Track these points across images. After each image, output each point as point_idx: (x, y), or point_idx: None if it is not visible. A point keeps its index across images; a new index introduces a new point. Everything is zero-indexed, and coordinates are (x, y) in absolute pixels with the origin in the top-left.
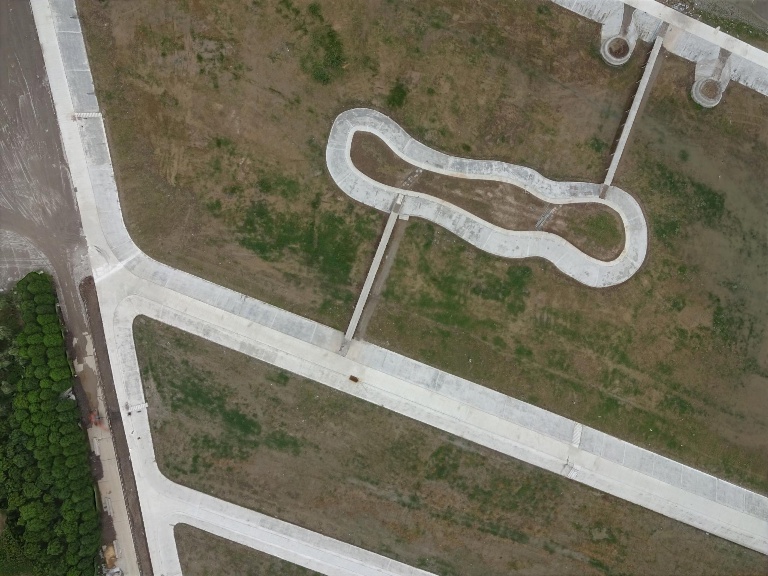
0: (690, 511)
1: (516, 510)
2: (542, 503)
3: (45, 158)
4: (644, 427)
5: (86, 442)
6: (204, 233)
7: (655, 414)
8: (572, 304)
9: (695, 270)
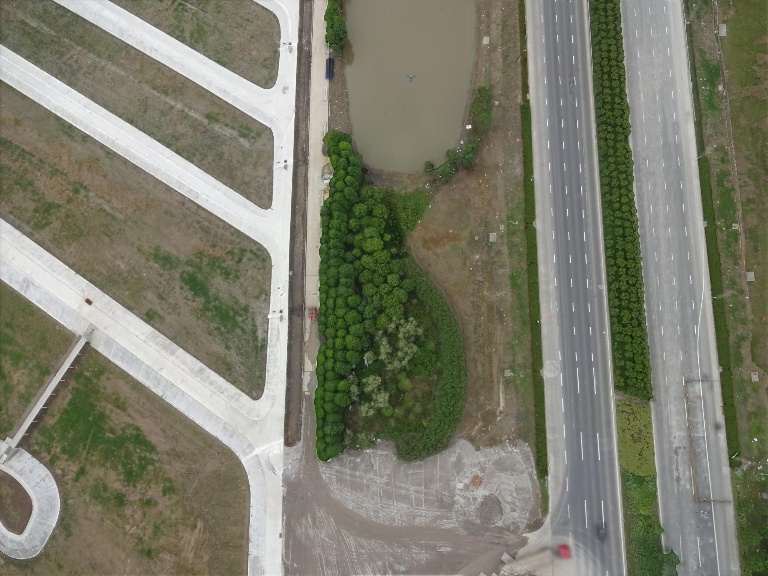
0: None
1: (0, 166)
2: None
3: (302, 575)
4: None
5: None
6: (184, 466)
7: None
8: None
9: None
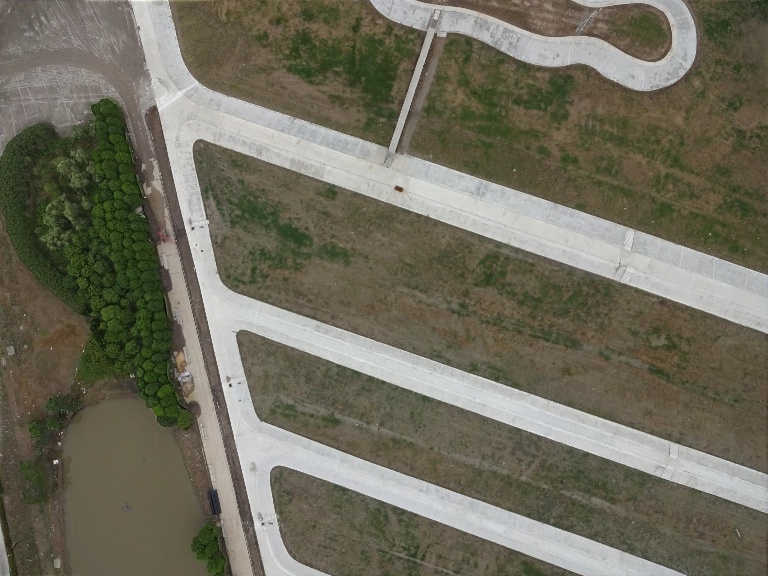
0: (757, 314)
1: (568, 316)
2: (595, 309)
3: (112, 2)
4: (702, 231)
5: (156, 256)
6: (254, 62)
7: (714, 218)
8: (618, 110)
9: (751, 68)
